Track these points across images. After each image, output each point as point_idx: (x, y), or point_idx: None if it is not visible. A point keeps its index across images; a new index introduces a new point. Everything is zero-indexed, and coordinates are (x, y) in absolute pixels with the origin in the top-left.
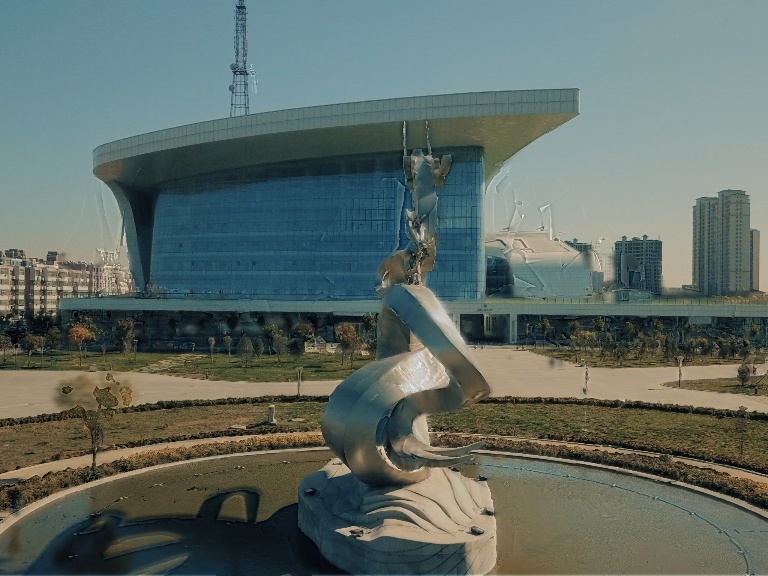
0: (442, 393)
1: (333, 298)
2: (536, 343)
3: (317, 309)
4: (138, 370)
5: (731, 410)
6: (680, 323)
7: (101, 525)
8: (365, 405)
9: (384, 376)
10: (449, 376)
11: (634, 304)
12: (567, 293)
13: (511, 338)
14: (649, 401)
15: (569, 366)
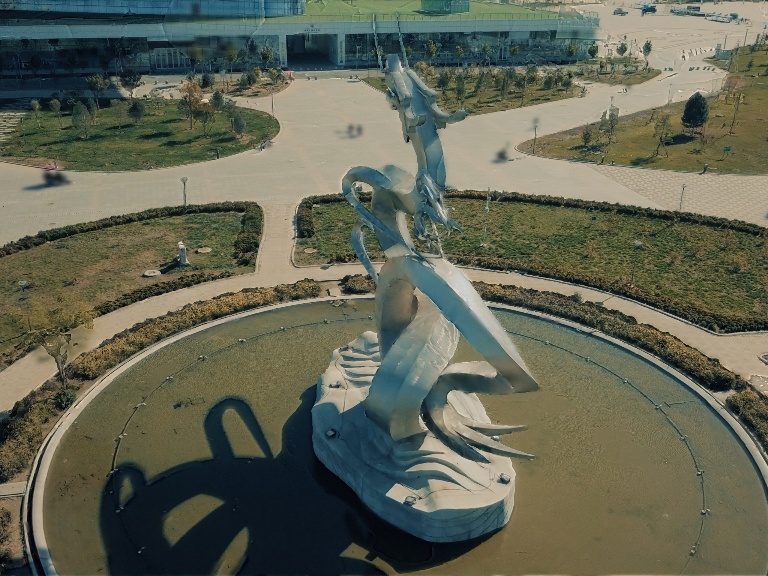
0: (485, 380)
1: (144, 20)
2: (369, 71)
3: (128, 34)
4: None
5: (597, 202)
6: (501, 39)
7: (130, 488)
8: (408, 389)
9: (420, 356)
10: (502, 378)
11: (459, 20)
12: None
13: (339, 60)
14: (524, 192)
15: None
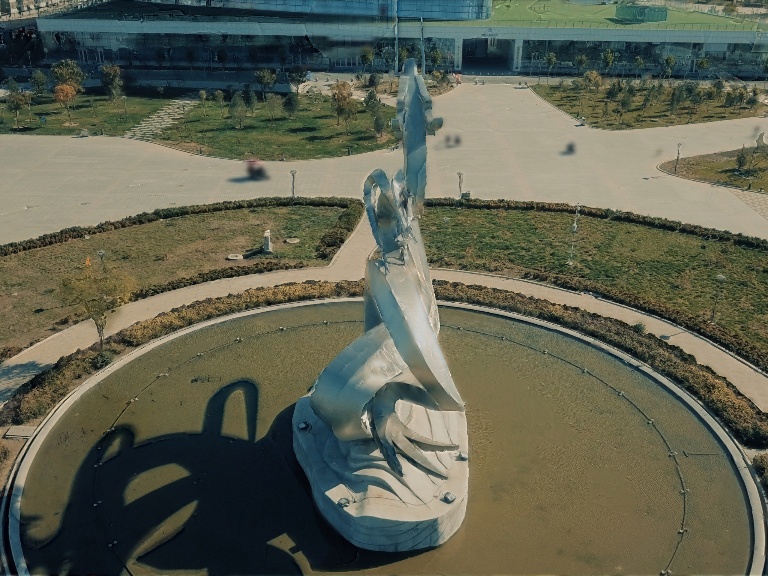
0: (422, 393)
1: None
2: (540, 78)
3: None
4: (130, 135)
5: (717, 230)
6: (694, 50)
7: (117, 447)
8: (351, 391)
9: (369, 360)
10: None
11: (648, 29)
12: (580, 1)
13: (515, 65)
14: (639, 213)
15: (569, 126)
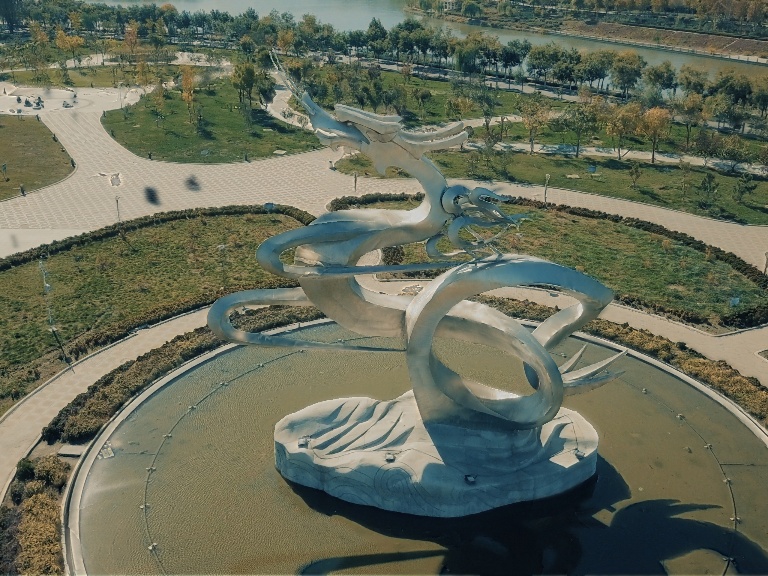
0: None
1: None
2: None
3: None
4: None
5: (36, 248)
6: None
7: None
8: None
9: None
10: None
11: None
12: None
13: None
14: None
15: None
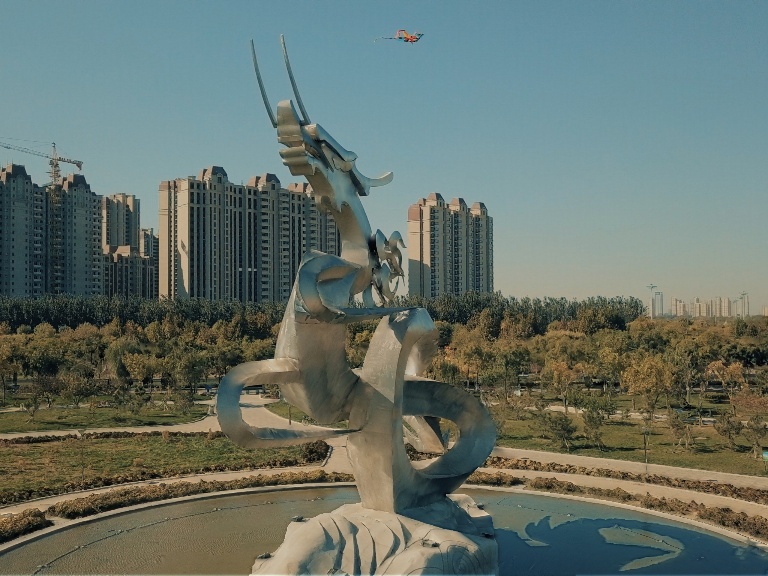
0: None
1: None
2: None
3: None
4: None
5: None
6: None
7: None
8: None
9: None
10: None
11: None
12: None
13: None
14: None
15: None
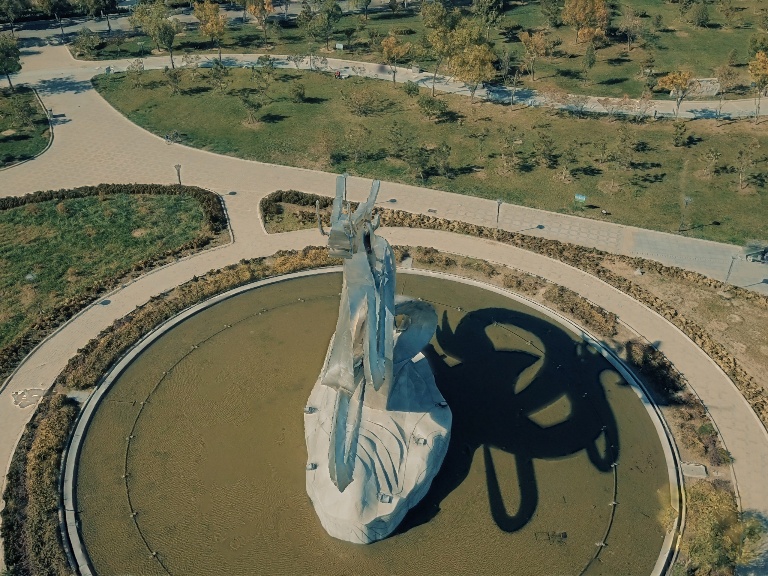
0: None
1: None
2: None
3: None
4: None
5: None
6: None
7: (599, 448)
8: None
9: None
10: None
11: None
12: None
13: None
14: None
15: None
